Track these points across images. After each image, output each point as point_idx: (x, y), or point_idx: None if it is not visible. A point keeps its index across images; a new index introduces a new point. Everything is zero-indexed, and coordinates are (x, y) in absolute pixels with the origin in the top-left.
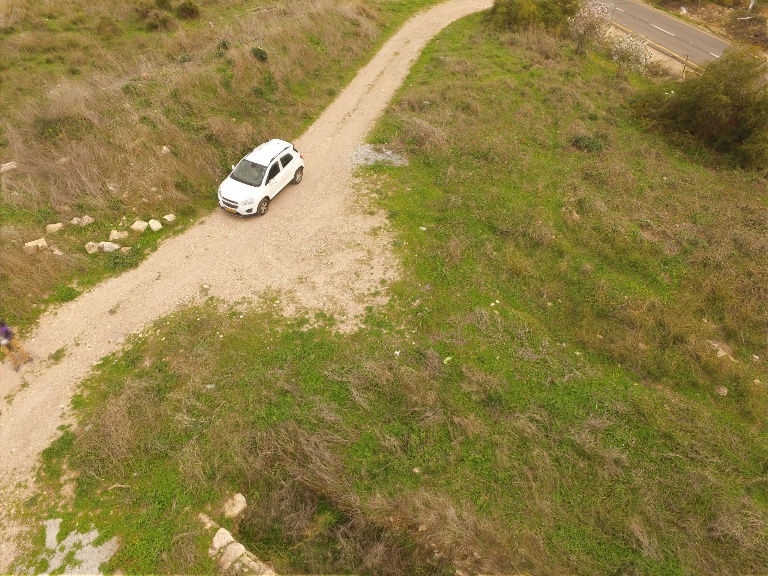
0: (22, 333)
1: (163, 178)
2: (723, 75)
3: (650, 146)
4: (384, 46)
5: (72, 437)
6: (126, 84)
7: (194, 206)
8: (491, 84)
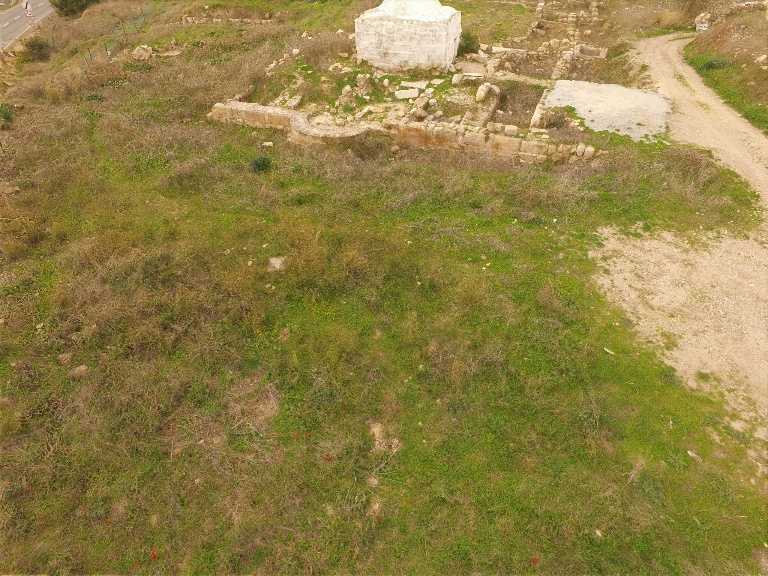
0: None
1: None
2: None
3: None
4: None
5: (706, 155)
6: None
7: None
8: None
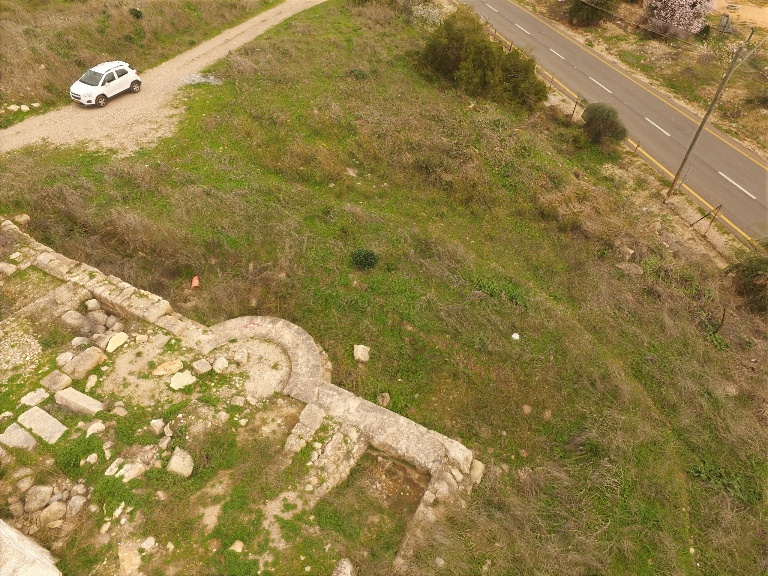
0: None
1: (34, 81)
2: (457, 27)
3: (408, 78)
4: (257, 16)
5: None
6: (26, 28)
7: (56, 101)
8: (317, 39)
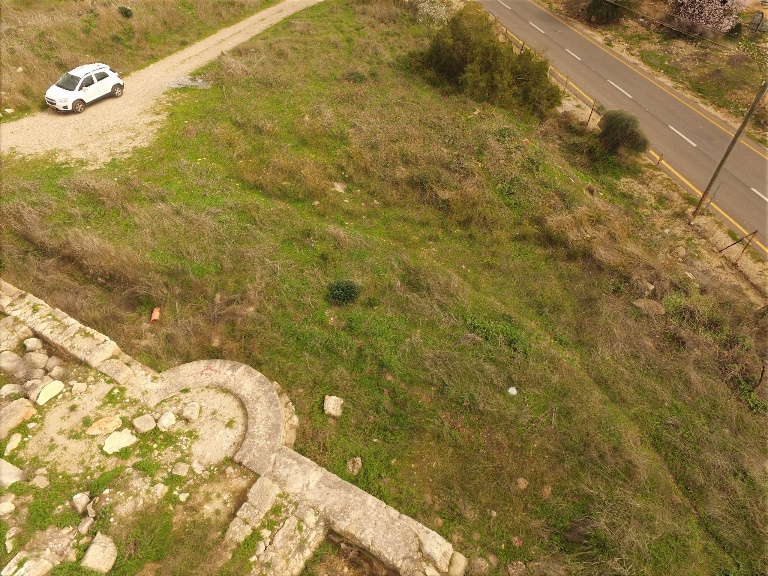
0: None
1: (9, 85)
2: (464, 26)
3: (409, 81)
4: (256, 14)
5: None
6: (8, 28)
7: (31, 106)
8: (316, 39)
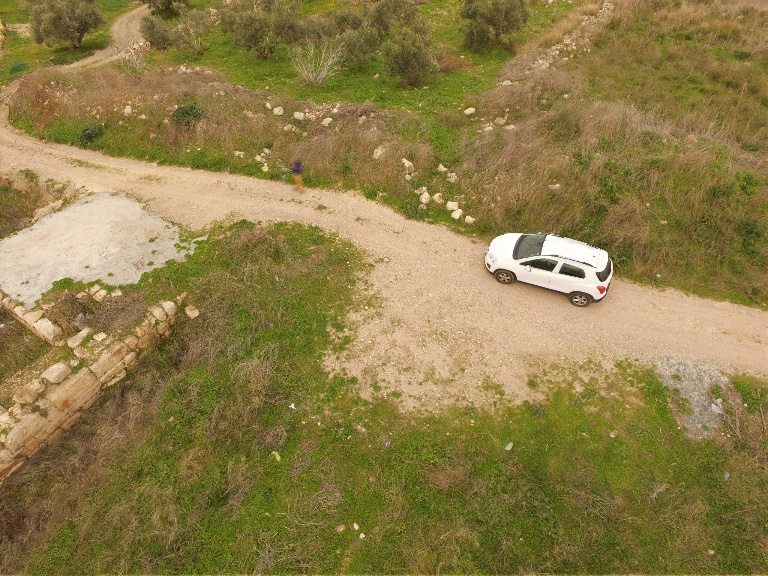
0: (338, 188)
1: (508, 196)
2: None
3: None
4: None
5: (250, 227)
6: (648, 131)
7: (494, 231)
8: None
